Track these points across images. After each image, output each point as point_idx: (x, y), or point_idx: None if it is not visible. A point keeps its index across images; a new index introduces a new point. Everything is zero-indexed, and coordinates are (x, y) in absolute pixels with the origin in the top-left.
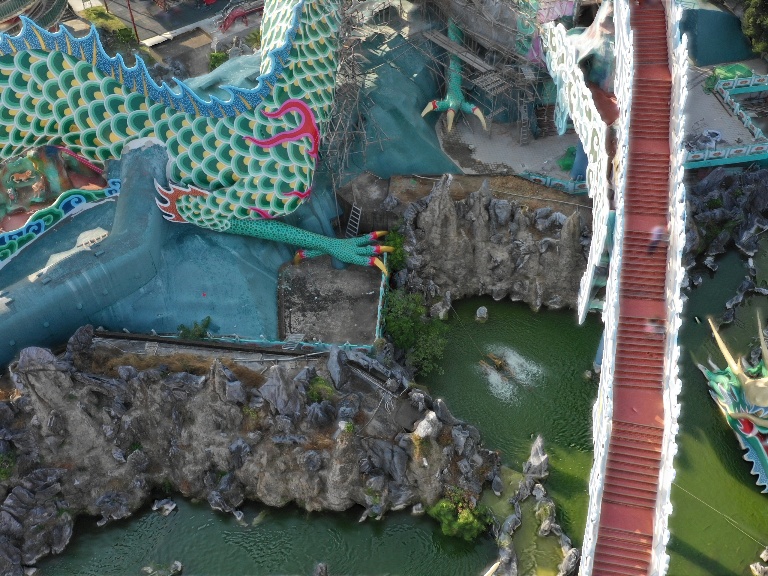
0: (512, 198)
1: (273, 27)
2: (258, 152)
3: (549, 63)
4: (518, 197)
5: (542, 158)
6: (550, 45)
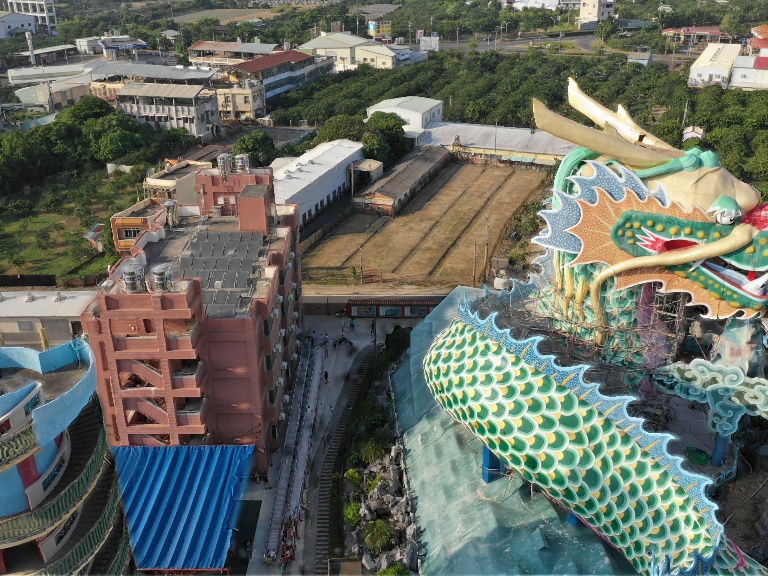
0: (760, 496)
1: (609, 473)
2: (749, 572)
3: (684, 392)
4: (759, 493)
5: (683, 467)
6: (681, 379)
